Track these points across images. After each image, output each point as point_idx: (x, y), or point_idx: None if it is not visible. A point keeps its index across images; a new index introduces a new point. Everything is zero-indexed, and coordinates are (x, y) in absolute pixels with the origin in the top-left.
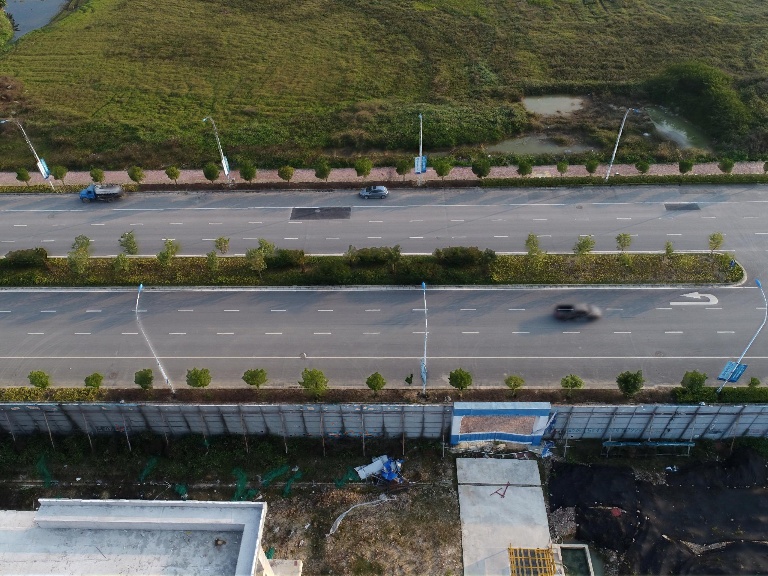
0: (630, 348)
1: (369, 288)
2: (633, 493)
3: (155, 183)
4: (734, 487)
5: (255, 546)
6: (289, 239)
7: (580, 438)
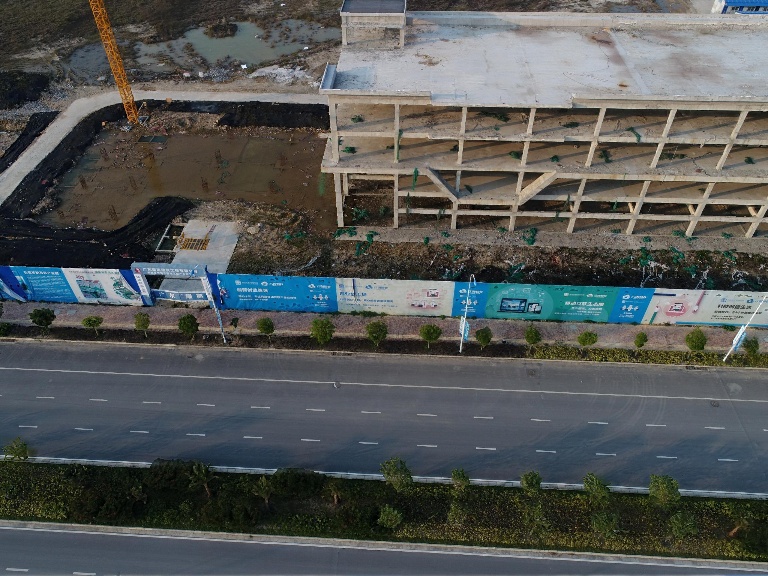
0: (2, 377)
1: (250, 471)
2: (106, 262)
3: None
4: (36, 264)
5: None
6: None
7: (114, 302)
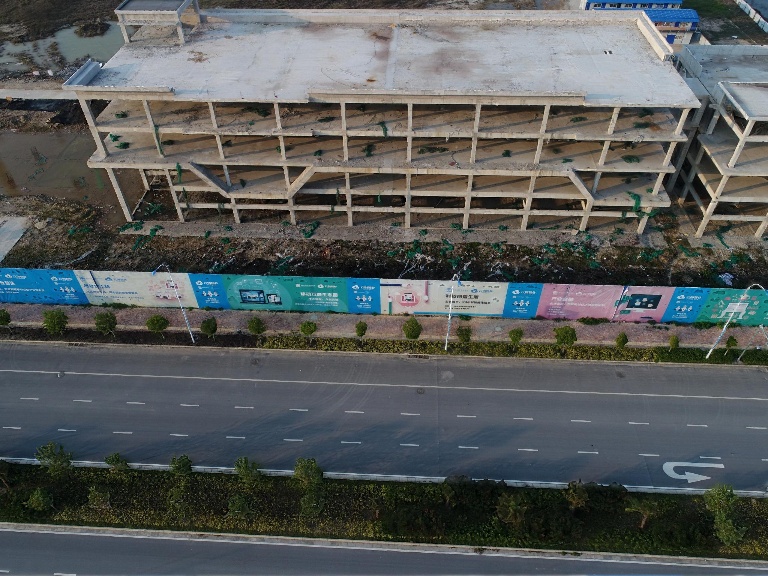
0: None
1: None
2: None
3: None
4: None
5: (74, 81)
6: (2, 569)
7: None
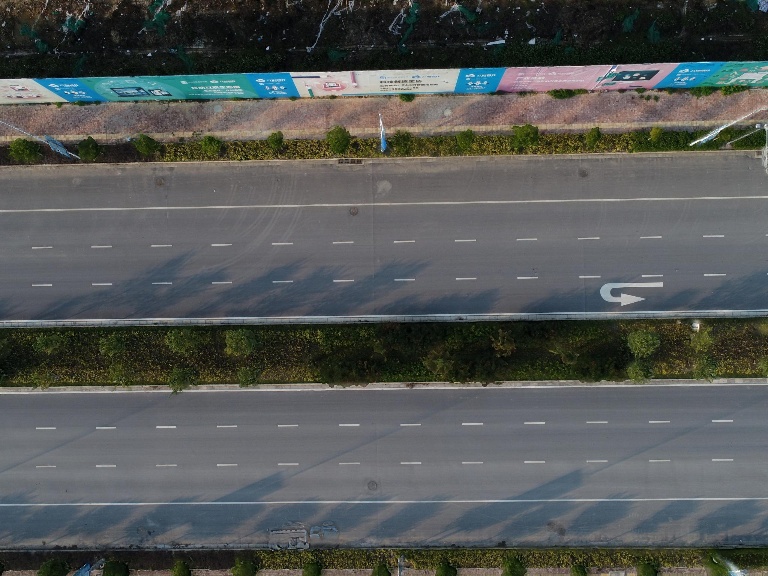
0: None
1: None
2: None
3: (231, 573)
4: None
5: None
6: None
7: None
